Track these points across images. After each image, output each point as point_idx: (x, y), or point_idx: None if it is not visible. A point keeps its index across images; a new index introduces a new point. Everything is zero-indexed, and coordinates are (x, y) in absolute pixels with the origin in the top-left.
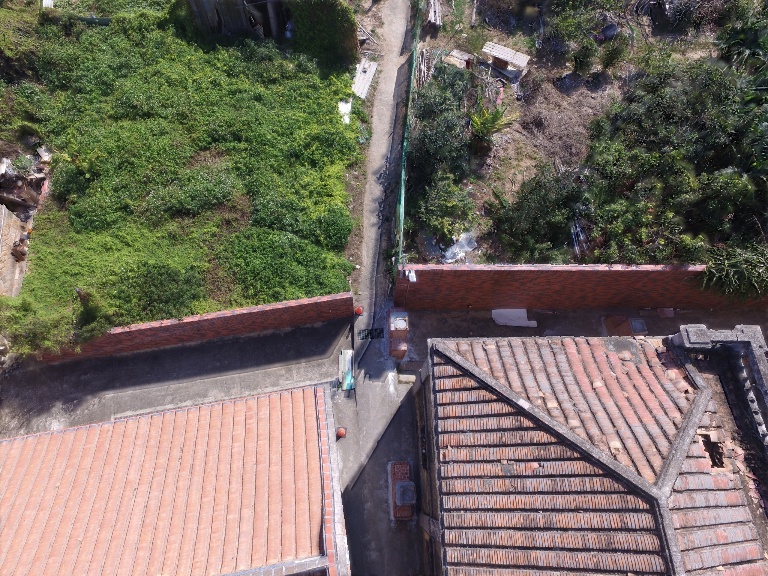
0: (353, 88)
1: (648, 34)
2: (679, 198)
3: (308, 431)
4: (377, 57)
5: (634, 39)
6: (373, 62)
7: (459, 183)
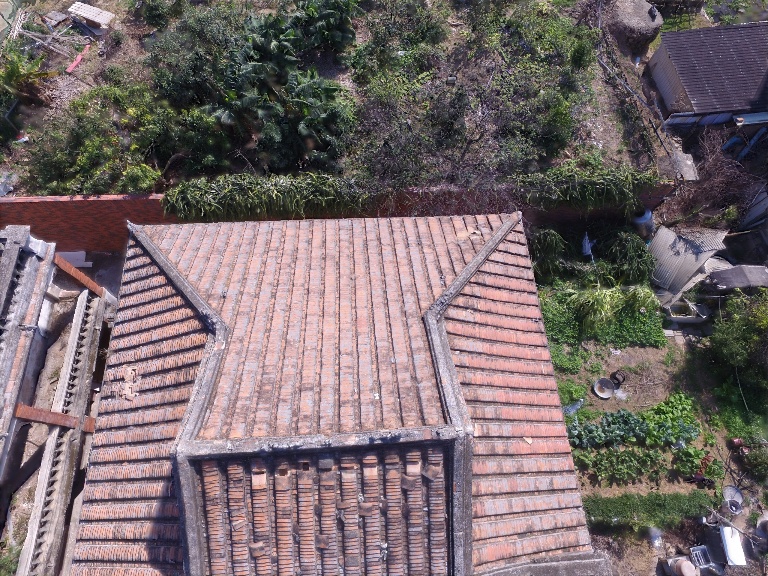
0: None
1: None
2: (140, 131)
3: None
4: None
5: None
6: None
7: None
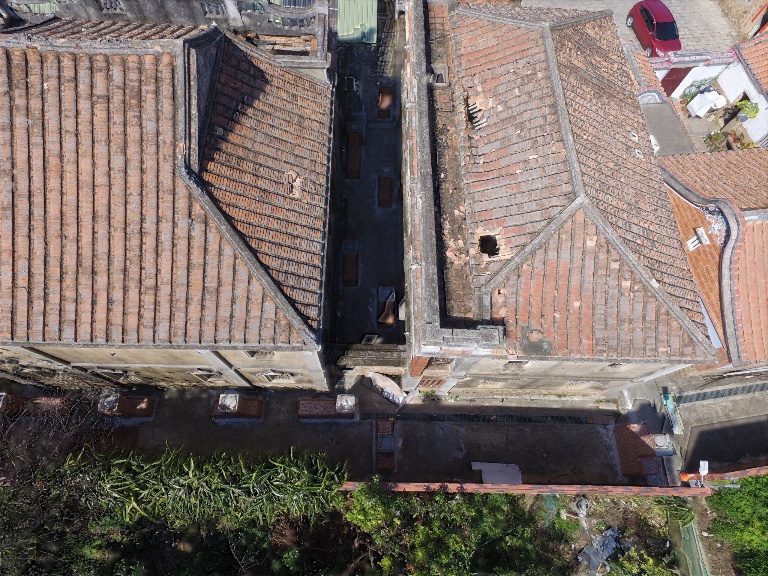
0: None
1: None
2: None
3: (750, 319)
4: None
5: None
6: None
7: None
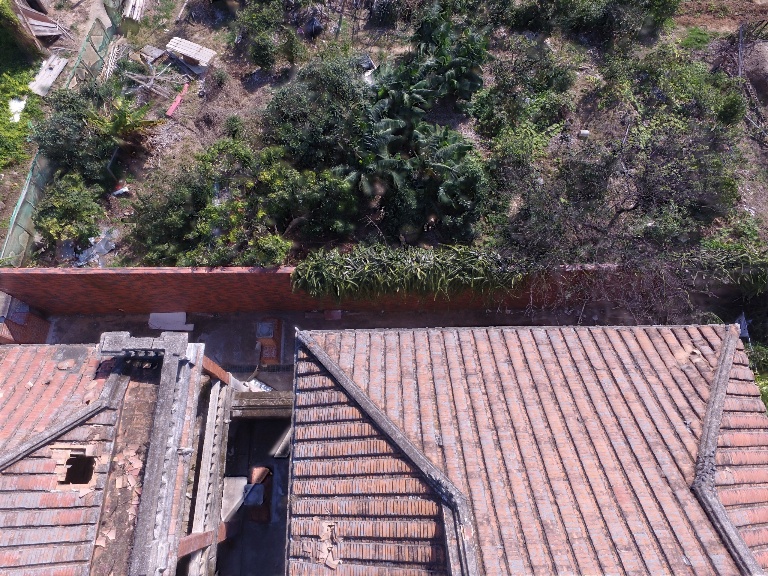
0: (31, 85)
1: (360, 28)
2: (268, 197)
3: None
4: (71, 53)
5: (339, 33)
6: (64, 59)
7: (95, 183)
